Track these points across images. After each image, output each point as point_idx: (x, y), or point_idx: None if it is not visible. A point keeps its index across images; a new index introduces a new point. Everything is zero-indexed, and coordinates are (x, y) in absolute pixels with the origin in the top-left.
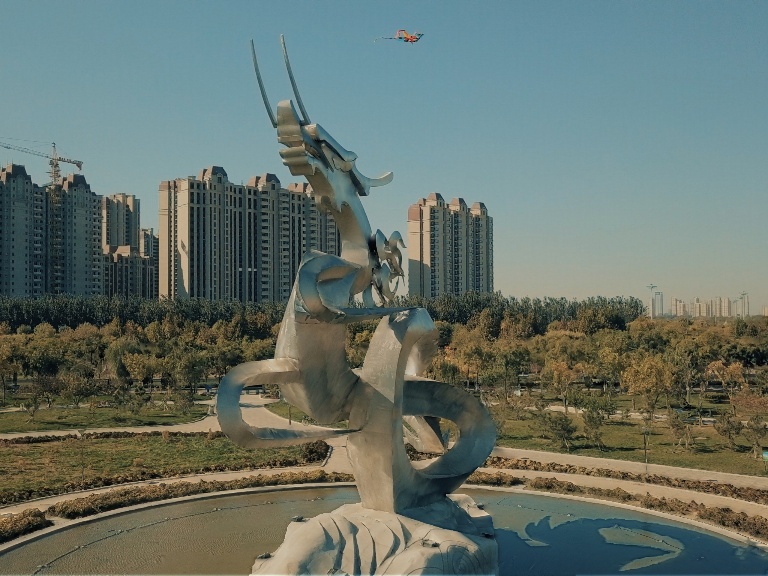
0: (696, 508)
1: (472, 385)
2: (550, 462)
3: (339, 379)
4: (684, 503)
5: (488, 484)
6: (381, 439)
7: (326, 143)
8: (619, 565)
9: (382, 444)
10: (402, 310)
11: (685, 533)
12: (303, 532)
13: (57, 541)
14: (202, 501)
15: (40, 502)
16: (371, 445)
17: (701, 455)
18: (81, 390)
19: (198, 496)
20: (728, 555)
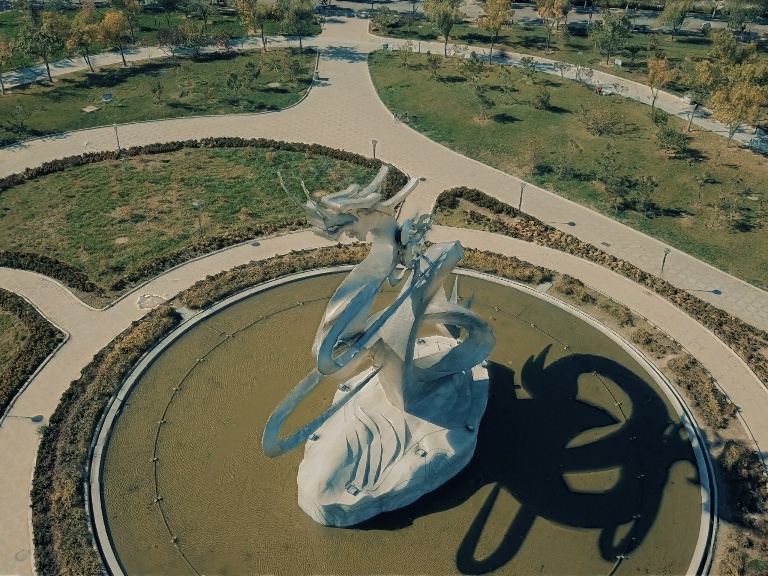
0: (673, 349)
1: (589, 6)
2: (589, 239)
3: None
4: (668, 338)
5: (520, 280)
6: (395, 378)
7: (350, 209)
8: (569, 438)
9: (396, 381)
10: (423, 275)
11: (643, 391)
12: (333, 449)
13: (185, 346)
14: (290, 285)
15: (172, 275)
16: (389, 378)
17: (734, 236)
18: (199, 41)
19: (287, 279)
20: (658, 432)
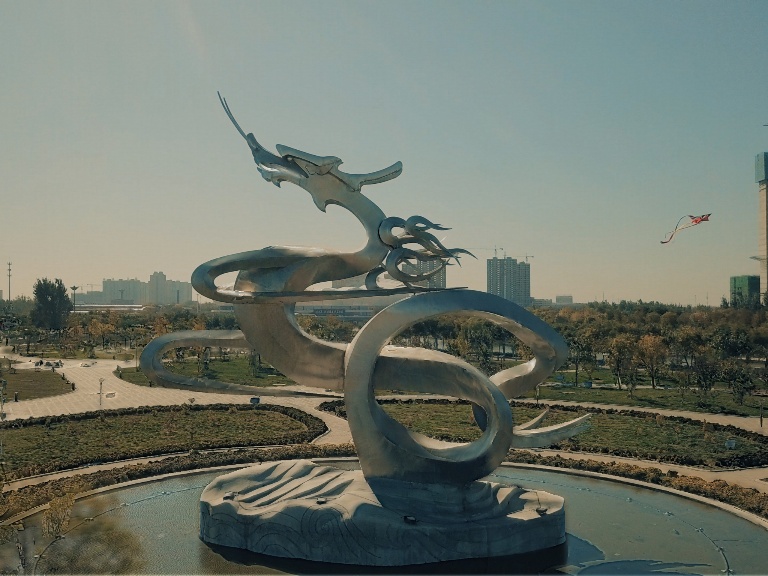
0: None
1: None
2: None
3: (306, 350)
4: None
5: None
6: None
7: (293, 156)
8: None
9: None
10: (411, 291)
11: None
12: None
13: None
14: (513, 469)
15: None
16: None
17: None
18: (734, 375)
19: (515, 464)
20: None
